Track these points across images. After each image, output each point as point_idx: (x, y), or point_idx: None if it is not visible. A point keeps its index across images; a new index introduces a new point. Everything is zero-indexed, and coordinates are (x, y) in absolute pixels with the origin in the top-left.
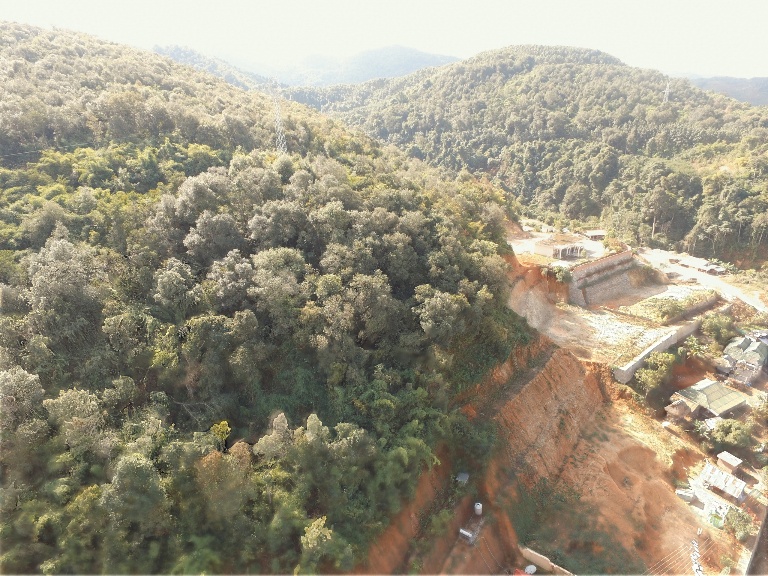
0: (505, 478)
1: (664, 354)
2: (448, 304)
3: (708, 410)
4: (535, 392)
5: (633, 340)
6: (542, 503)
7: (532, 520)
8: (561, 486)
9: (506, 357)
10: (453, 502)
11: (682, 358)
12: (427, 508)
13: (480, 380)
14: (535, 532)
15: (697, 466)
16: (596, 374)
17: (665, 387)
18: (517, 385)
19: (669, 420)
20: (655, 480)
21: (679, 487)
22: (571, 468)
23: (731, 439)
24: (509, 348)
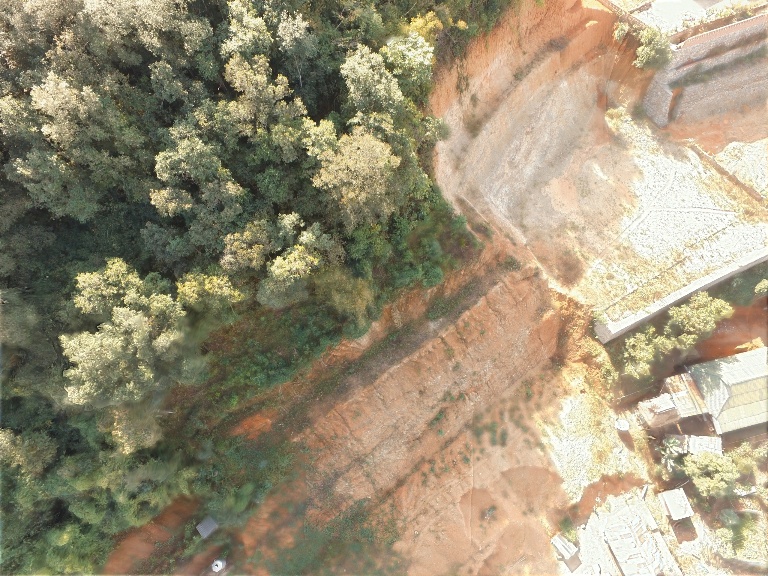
0: (287, 514)
1: (716, 304)
2: (143, 342)
3: (712, 419)
4: (409, 374)
5: (685, 252)
6: (341, 534)
7: (313, 557)
8: (383, 511)
9: (358, 336)
10: (172, 568)
11: (756, 297)
12: (133, 569)
13: (288, 380)
14: (308, 574)
15: (621, 496)
16: (565, 317)
17: (677, 350)
18: (378, 364)
19: (637, 413)
20: (534, 517)
21: (562, 534)
22: (416, 484)
23: (701, 487)
24: (368, 324)
